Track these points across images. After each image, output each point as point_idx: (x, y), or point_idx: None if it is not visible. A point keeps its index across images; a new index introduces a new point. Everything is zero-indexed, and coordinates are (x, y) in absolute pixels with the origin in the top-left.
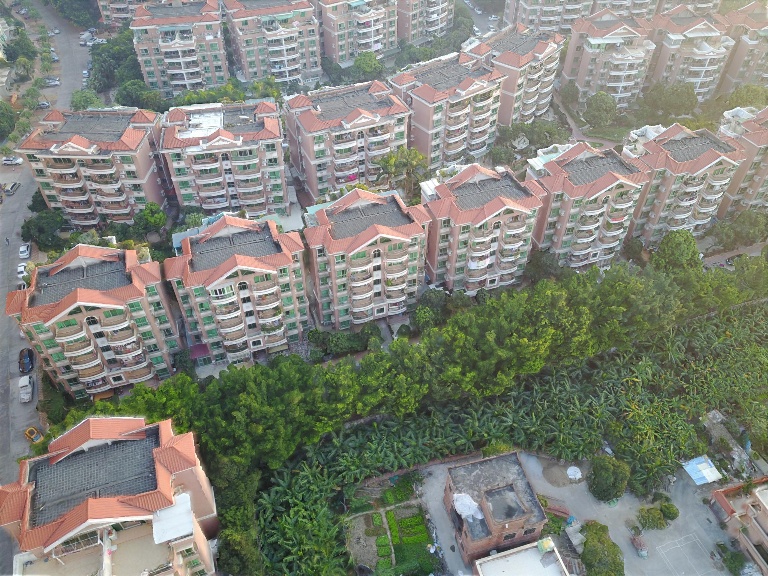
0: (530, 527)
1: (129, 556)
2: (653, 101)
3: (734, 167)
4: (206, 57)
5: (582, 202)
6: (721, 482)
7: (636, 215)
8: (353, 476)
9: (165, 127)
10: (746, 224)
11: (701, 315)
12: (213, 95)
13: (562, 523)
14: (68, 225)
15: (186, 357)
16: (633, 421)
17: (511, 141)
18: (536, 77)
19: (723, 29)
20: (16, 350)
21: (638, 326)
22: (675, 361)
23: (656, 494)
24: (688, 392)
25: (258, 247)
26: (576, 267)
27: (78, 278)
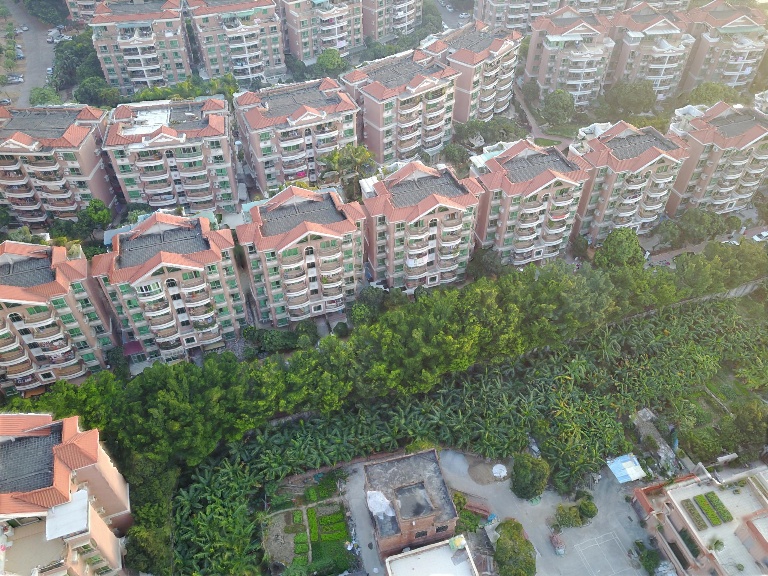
0: (441, 525)
1: (23, 552)
2: (613, 99)
3: (678, 165)
4: (166, 54)
5: (521, 200)
6: (646, 480)
7: (582, 213)
8: (274, 473)
9: (113, 124)
10: (692, 222)
11: (640, 313)
12: (169, 92)
13: (482, 521)
14: (16, 222)
15: (119, 354)
16: (561, 419)
17: (469, 139)
18: (493, 74)
19: (683, 27)
20: None
21: (568, 324)
22: (609, 359)
23: (578, 492)
24: (619, 390)
25: (188, 244)
26: (520, 265)
27: (3, 275)
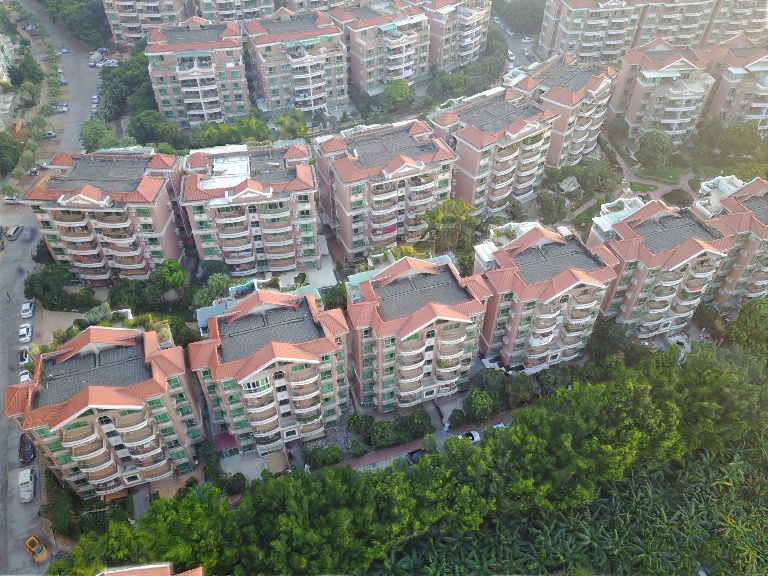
0: None
1: None
2: (710, 139)
3: None
4: (226, 85)
5: (659, 271)
6: None
7: None
8: None
9: (185, 172)
10: None
11: None
12: (235, 130)
13: None
14: (76, 279)
15: (210, 450)
16: (729, 538)
17: (558, 182)
18: None
19: None
20: (16, 433)
21: (734, 425)
22: None
23: None
24: None
25: (296, 329)
26: (645, 338)
27: (89, 368)
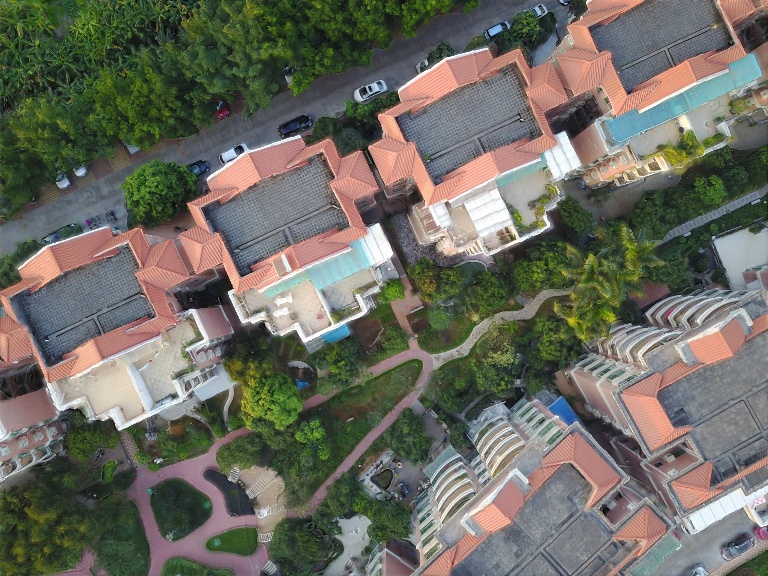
0: None
1: None
2: None
3: None
4: None
5: None
6: None
7: None
8: None
9: None
10: None
11: None
12: None
13: None
14: None
15: None
16: None
17: None
18: None
19: None
20: None
21: None
22: None
23: None
24: None
25: None
26: None
27: None
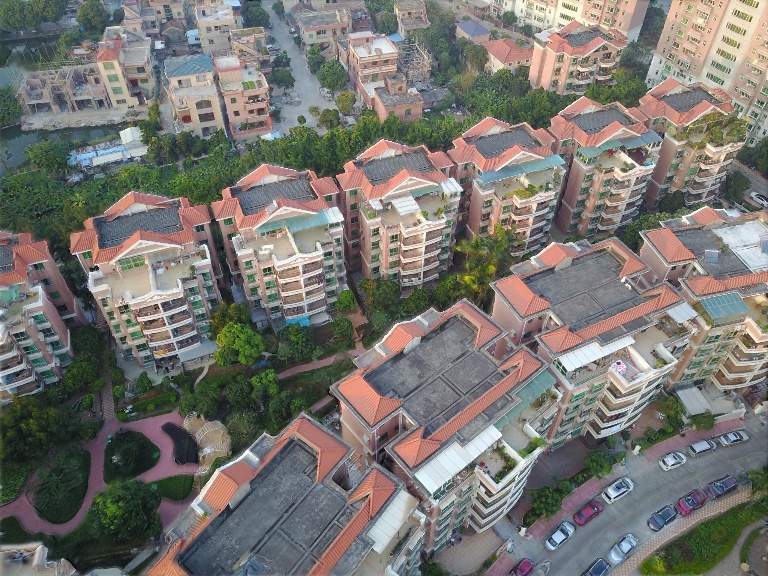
0: None
1: None
2: None
3: None
4: None
5: None
6: None
7: None
8: None
9: None
10: None
11: None
12: None
13: None
14: None
15: None
16: None
17: None
18: None
19: None
20: None
21: None
22: None
23: None
24: None
25: (583, 126)
26: None
27: None
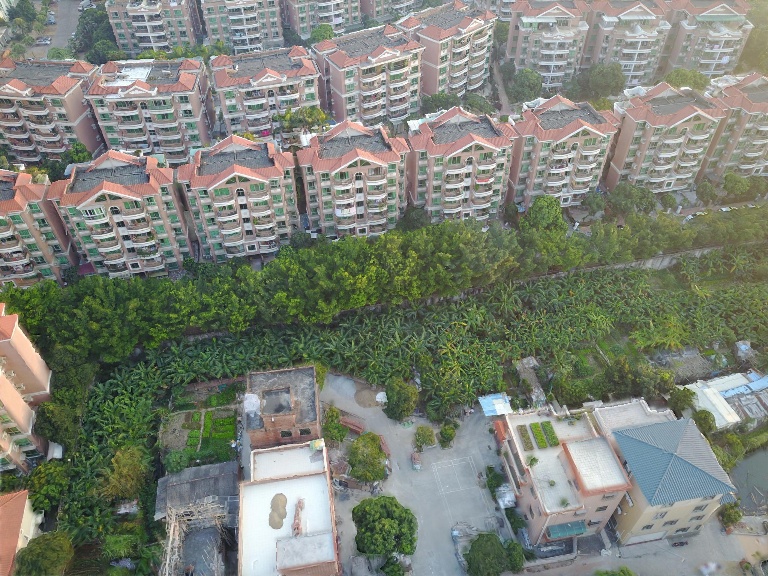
0: (301, 426)
1: None
2: (586, 82)
3: (605, 139)
4: (171, 22)
5: (444, 161)
6: None
7: (514, 181)
8: (180, 378)
9: None
10: (620, 196)
11: (549, 274)
12: None
13: (355, 436)
14: (16, 161)
15: (73, 272)
16: (447, 358)
17: None
18: (463, 52)
19: (660, 13)
20: None
21: (463, 272)
22: (508, 311)
23: None
24: (508, 338)
25: (133, 178)
26: None
27: None
